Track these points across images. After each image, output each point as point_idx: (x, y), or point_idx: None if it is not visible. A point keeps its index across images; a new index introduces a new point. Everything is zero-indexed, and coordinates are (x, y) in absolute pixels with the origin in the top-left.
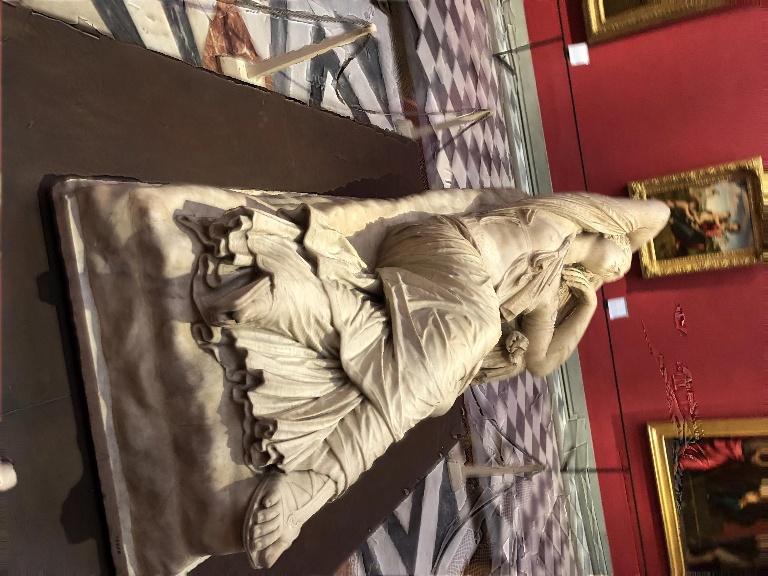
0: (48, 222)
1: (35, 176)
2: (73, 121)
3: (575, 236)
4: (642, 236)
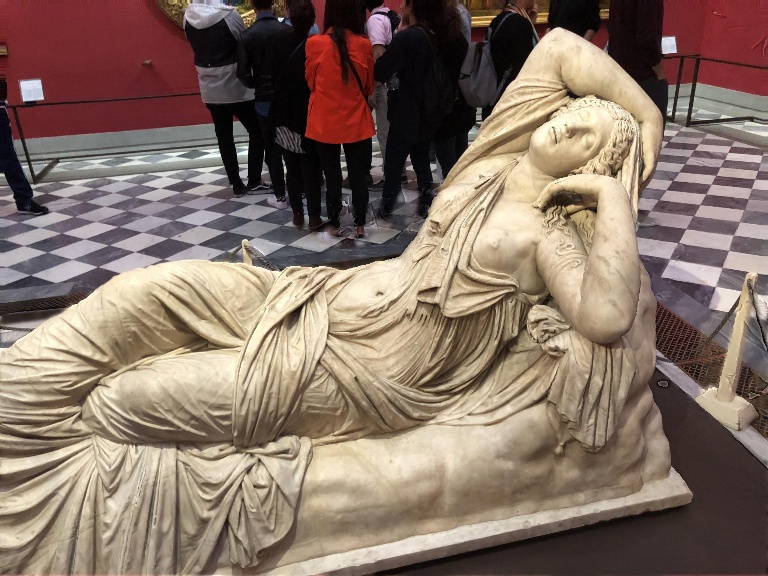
0: None
1: None
2: None
3: (508, 166)
4: (578, 75)
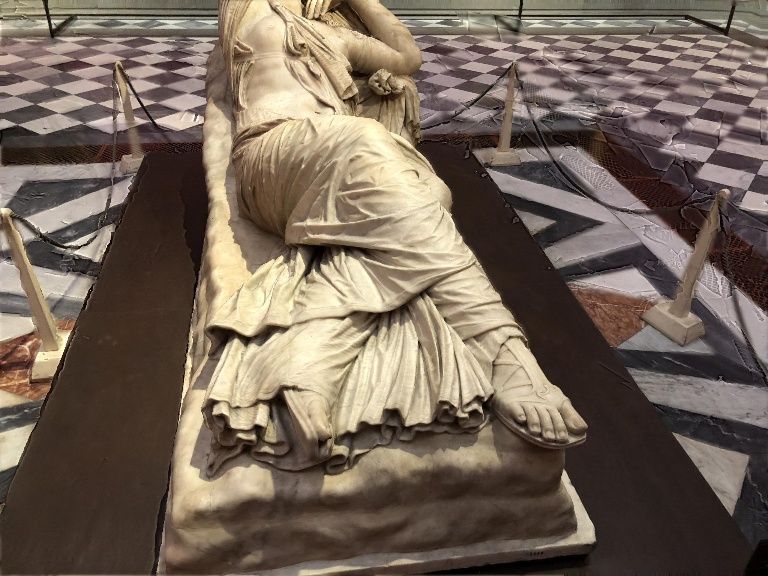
0: None
1: None
2: (92, 570)
3: None
4: None
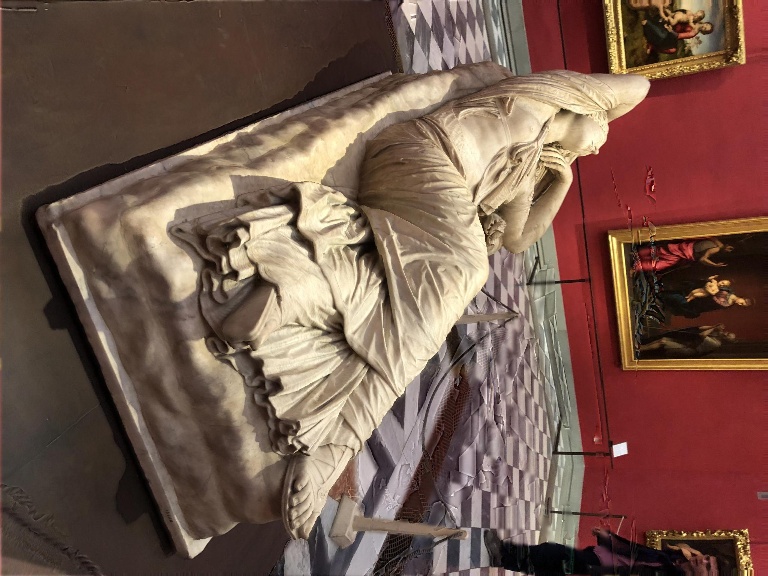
0: (39, 248)
1: (14, 205)
2: (34, 125)
3: (554, 118)
4: (620, 111)
